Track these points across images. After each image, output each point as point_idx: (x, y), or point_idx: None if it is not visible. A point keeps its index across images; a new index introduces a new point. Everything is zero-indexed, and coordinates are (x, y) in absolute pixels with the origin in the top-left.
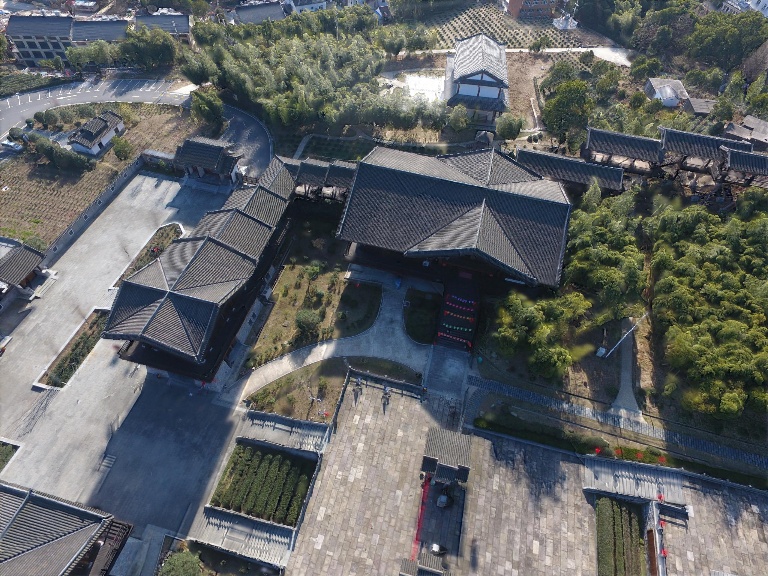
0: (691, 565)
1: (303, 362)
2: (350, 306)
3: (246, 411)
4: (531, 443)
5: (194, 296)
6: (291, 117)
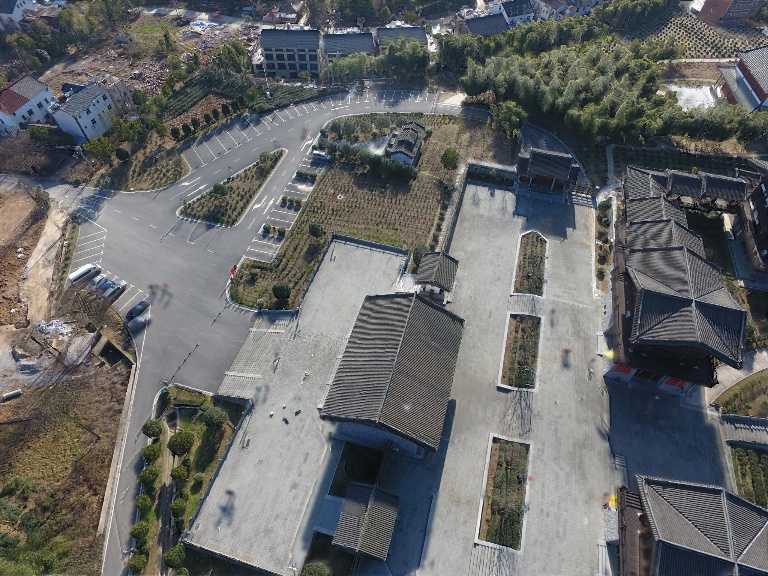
0: None
1: (752, 368)
2: (766, 314)
3: (719, 415)
4: None
5: None
6: (609, 128)
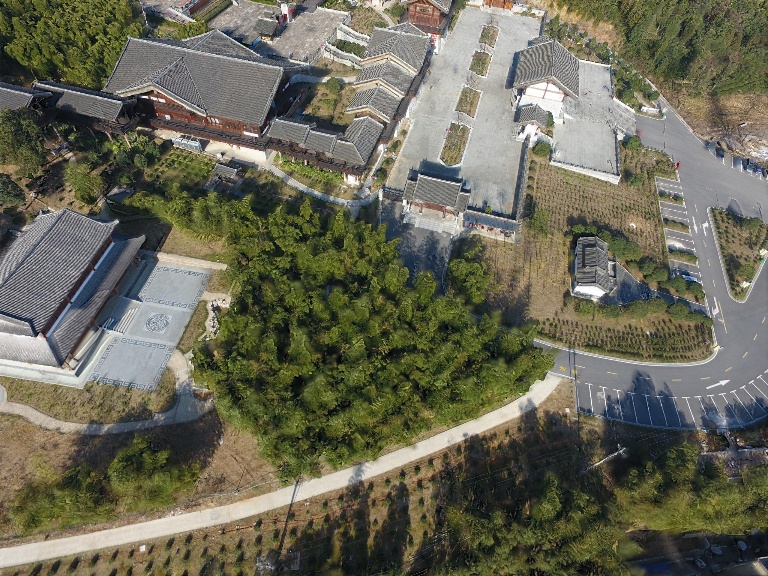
0: (182, 2)
1: None
2: None
3: None
4: None
5: (388, 33)
6: None
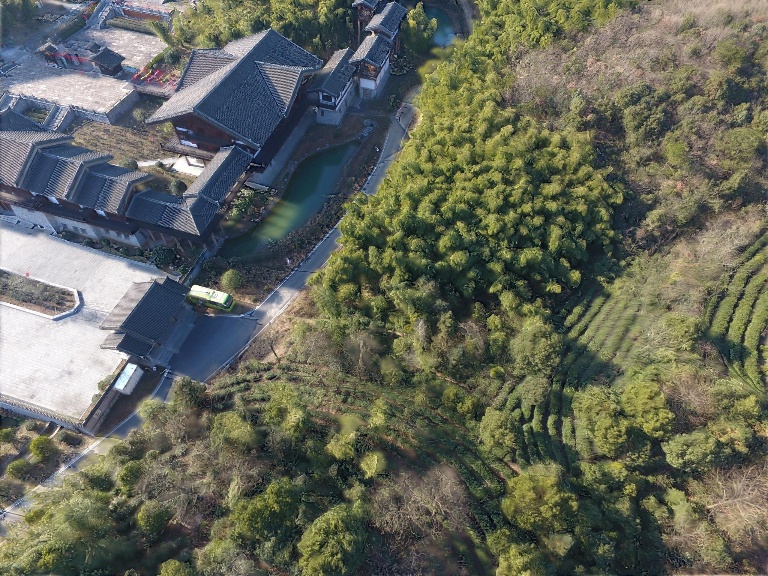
0: (139, 4)
1: None
2: None
3: None
4: (70, 38)
5: None
6: None
